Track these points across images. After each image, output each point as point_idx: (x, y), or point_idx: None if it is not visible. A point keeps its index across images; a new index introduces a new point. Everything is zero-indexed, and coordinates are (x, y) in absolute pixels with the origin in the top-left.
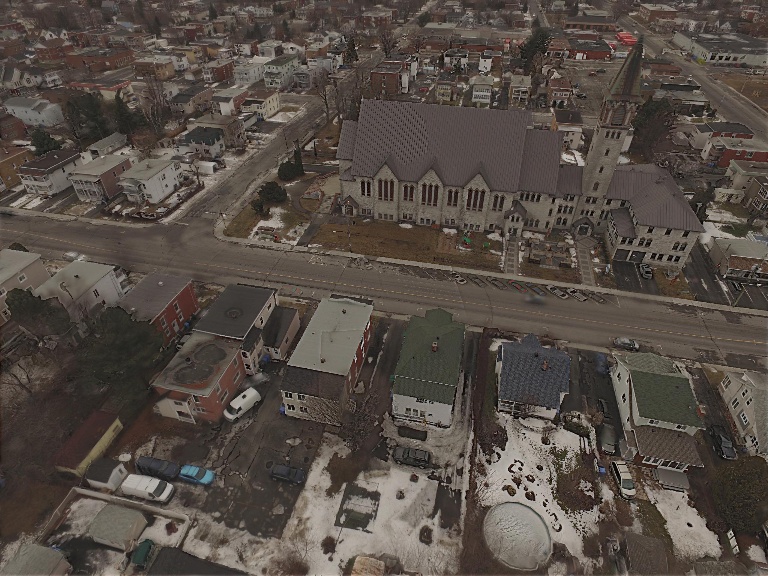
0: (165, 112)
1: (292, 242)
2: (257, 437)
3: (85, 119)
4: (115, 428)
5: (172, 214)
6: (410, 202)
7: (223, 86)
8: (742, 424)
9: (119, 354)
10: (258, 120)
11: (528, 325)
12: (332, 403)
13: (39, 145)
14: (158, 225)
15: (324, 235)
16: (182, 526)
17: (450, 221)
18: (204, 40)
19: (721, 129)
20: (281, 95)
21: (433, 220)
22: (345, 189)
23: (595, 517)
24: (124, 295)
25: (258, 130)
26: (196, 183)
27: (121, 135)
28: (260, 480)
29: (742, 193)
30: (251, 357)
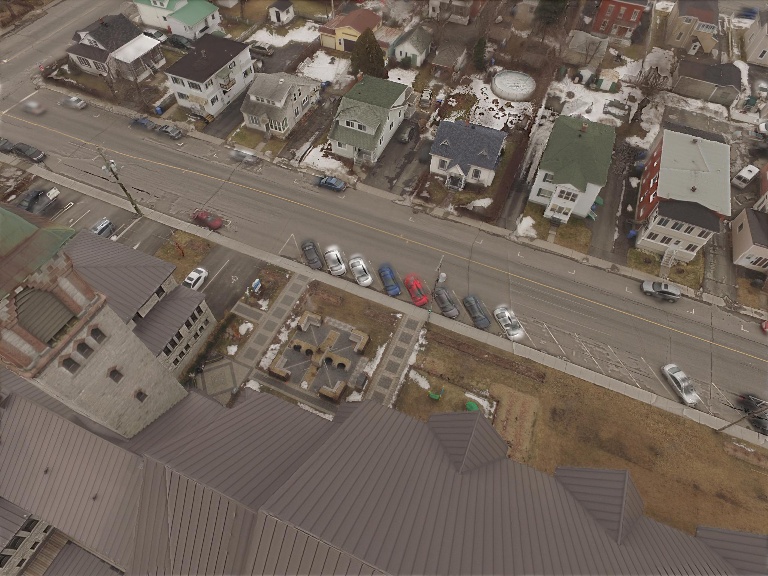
0: None
1: None
2: None
3: None
4: None
5: None
6: None
7: None
8: None
9: None
10: None
11: (432, 227)
12: None
13: None
14: None
15: None
16: None
17: None
18: None
19: None
20: None
21: None
22: None
23: (456, 90)
24: None
25: None
26: None
27: None
28: None
29: None
30: None
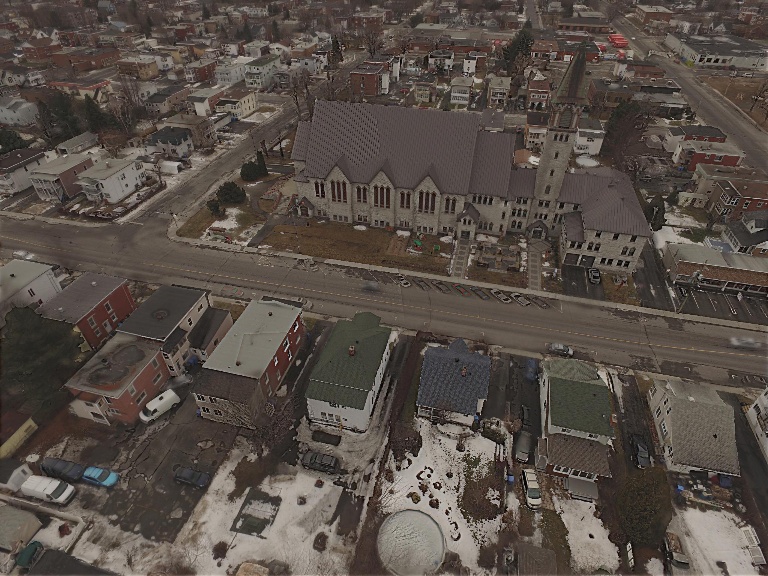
0: (140, 112)
1: (243, 243)
2: (169, 439)
3: (56, 118)
4: (28, 428)
5: (129, 214)
6: (364, 204)
7: (204, 86)
8: (662, 433)
9: (26, 354)
10: (232, 120)
11: (465, 329)
12: (242, 406)
13: (5, 144)
14: (113, 225)
15: (276, 236)
16: (75, 528)
17: (404, 223)
18: (192, 40)
19: (693, 132)
20: (261, 95)
21: (387, 222)
22: (300, 190)
23: (496, 526)
24: (55, 295)
25: (230, 130)
26: (159, 183)
27: (92, 134)
28: (164, 483)
29: (705, 197)
30: (173, 359)
